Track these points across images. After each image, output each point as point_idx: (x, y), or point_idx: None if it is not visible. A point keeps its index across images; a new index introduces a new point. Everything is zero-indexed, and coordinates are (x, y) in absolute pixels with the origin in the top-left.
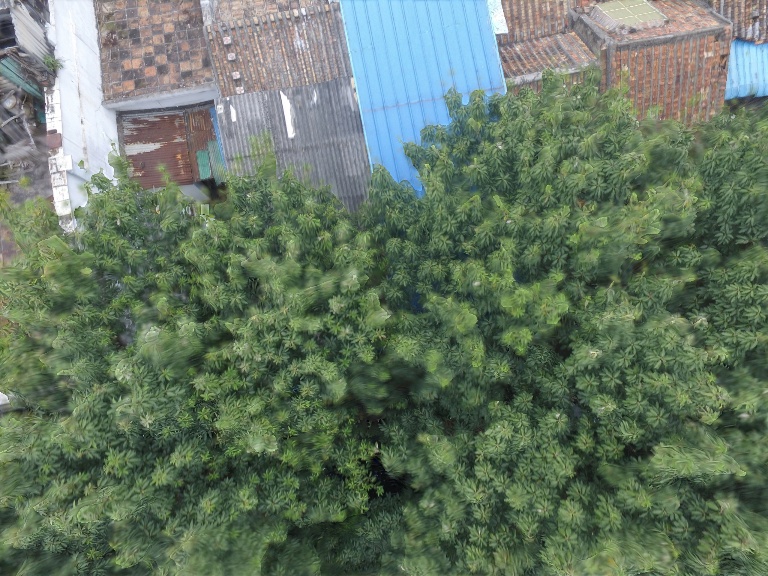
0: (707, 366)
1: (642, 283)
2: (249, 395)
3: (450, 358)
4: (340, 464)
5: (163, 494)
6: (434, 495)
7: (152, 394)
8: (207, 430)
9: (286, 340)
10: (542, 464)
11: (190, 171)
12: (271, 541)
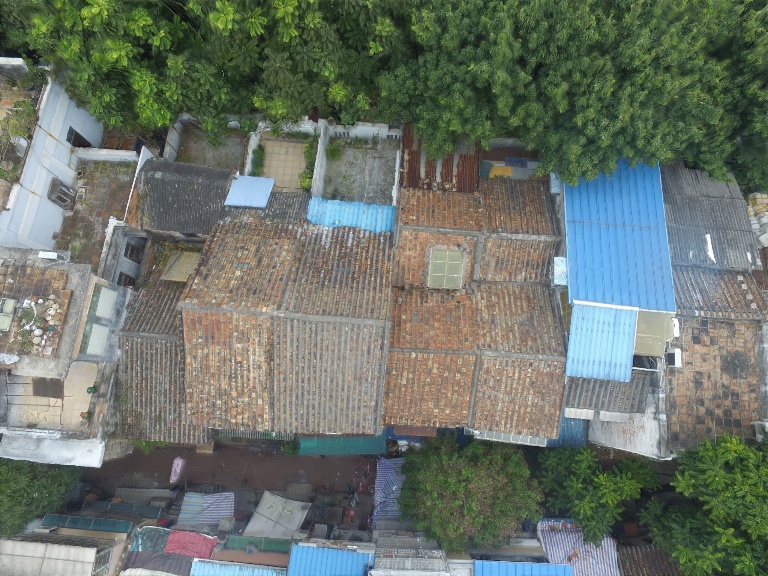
0: None
1: None
2: None
3: None
4: None
5: None
6: None
7: None
8: None
9: None
10: None
11: (766, 254)
12: None
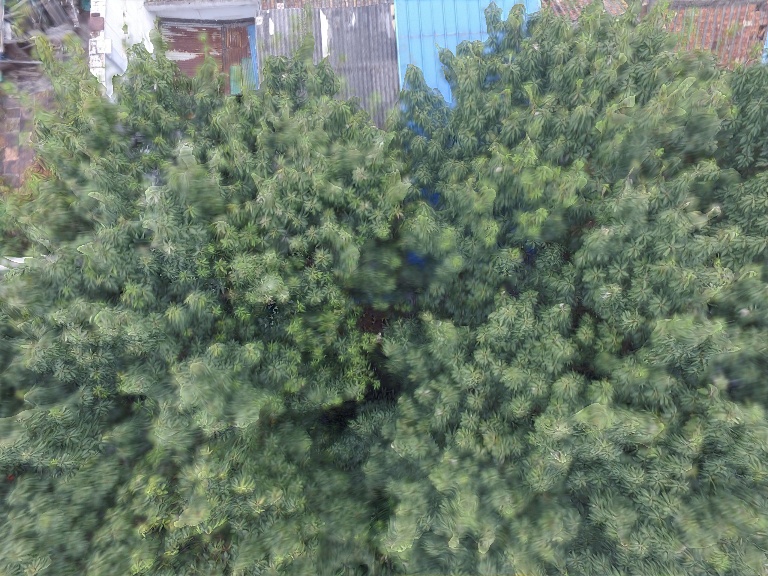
0: (715, 248)
1: (660, 180)
2: (265, 255)
3: (462, 247)
4: (341, 353)
5: (173, 337)
6: (430, 382)
7: (176, 223)
8: (221, 285)
9: (307, 204)
10: (540, 352)
11: (222, 85)
12: (269, 404)
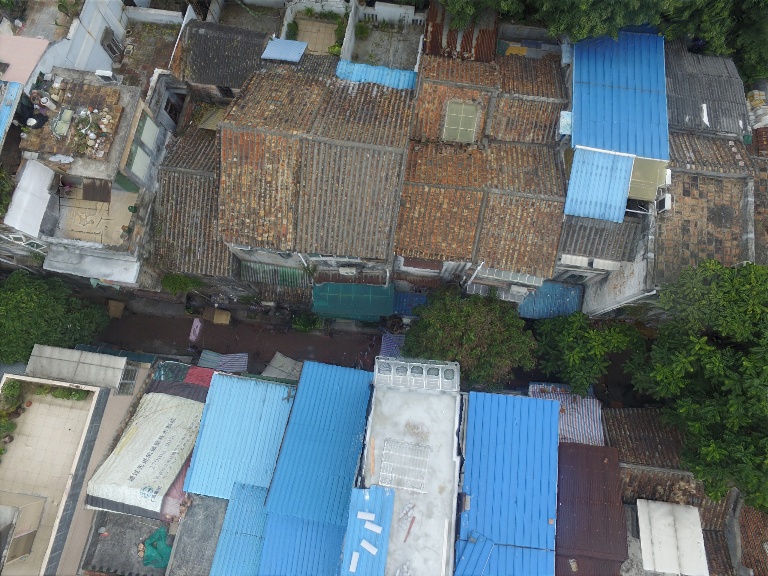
0: None
1: None
2: None
3: None
4: None
5: None
6: None
7: None
8: None
9: None
10: None
11: (758, 134)
12: None
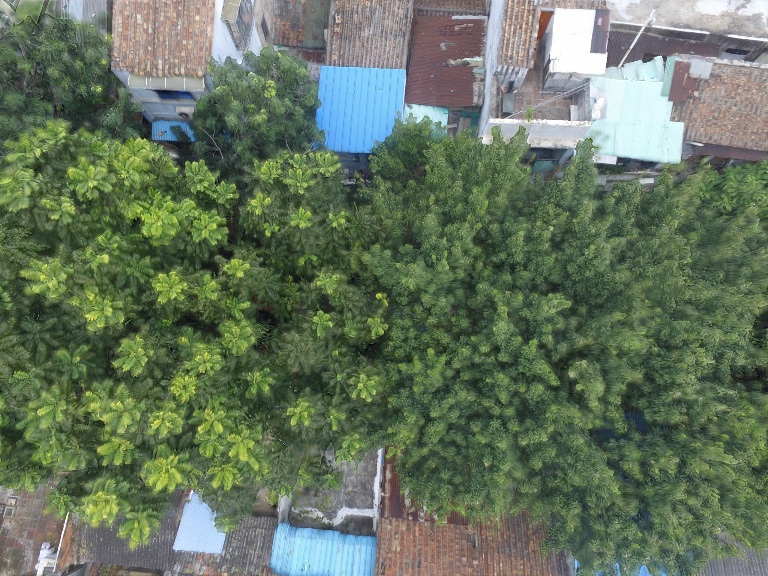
0: None
1: (678, 420)
2: None
3: None
4: None
5: None
6: None
7: None
8: None
9: None
10: None
11: None
12: None
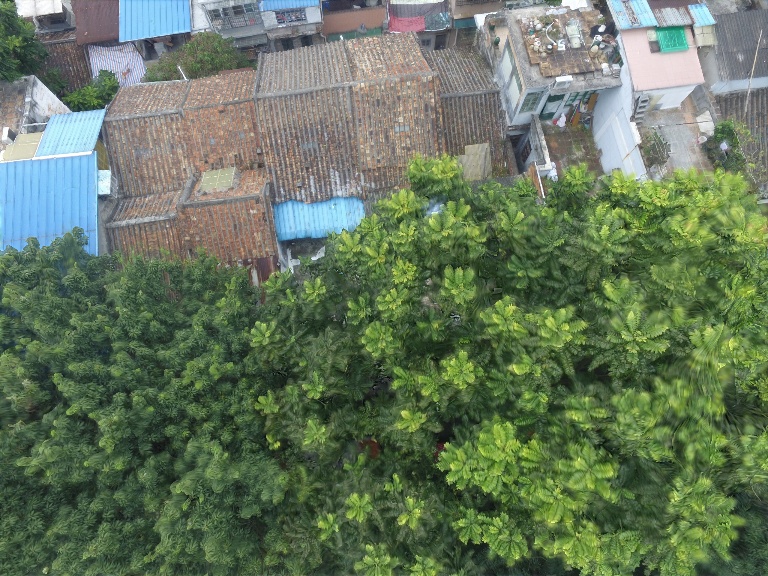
0: None
1: None
2: None
3: None
4: None
5: None
6: None
7: None
8: None
9: None
10: None
11: None
12: None
